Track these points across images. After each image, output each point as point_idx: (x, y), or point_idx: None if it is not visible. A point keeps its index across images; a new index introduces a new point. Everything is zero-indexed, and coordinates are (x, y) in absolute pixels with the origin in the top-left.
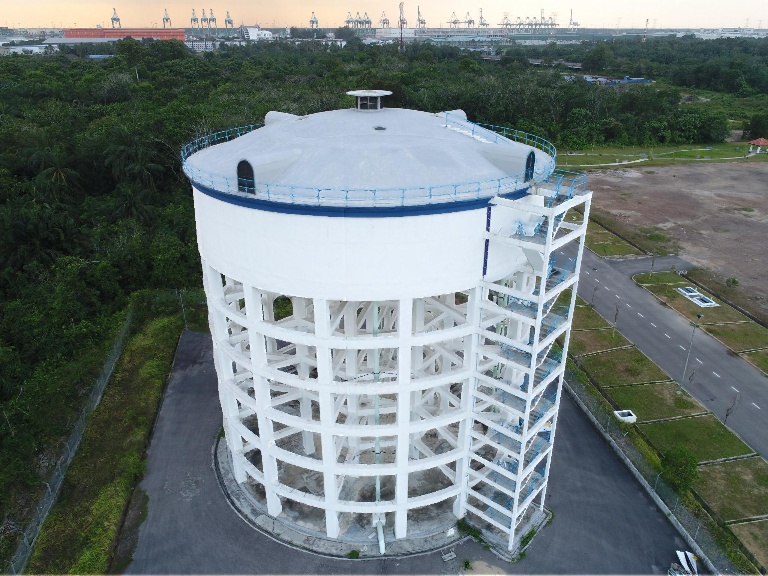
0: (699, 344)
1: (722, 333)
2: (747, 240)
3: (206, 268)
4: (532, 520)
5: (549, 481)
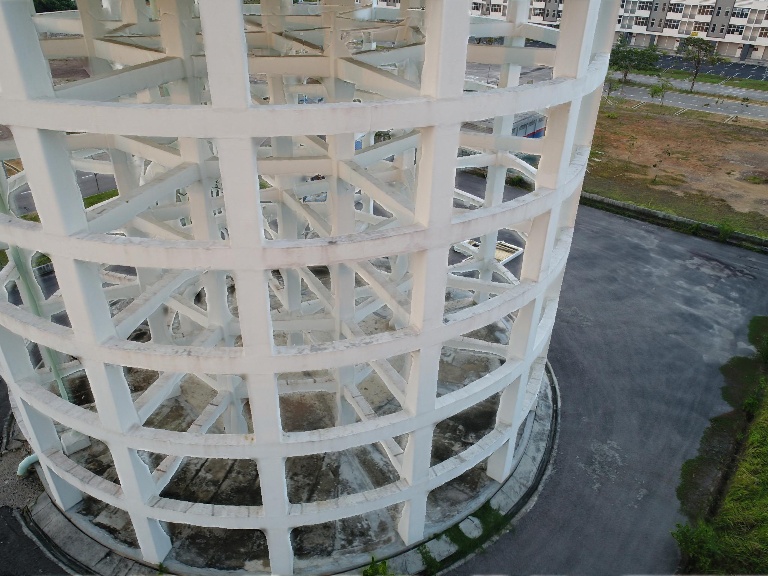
0: None
1: None
2: None
3: None
4: None
5: None
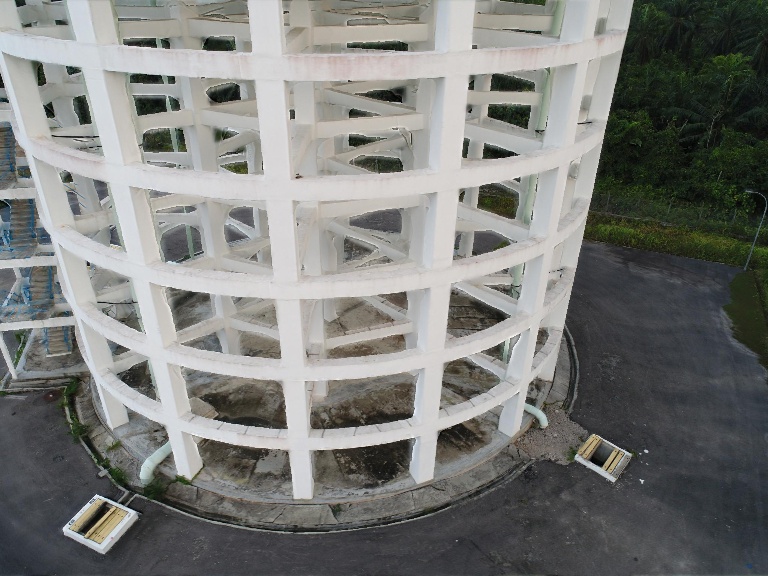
0: None
1: None
2: None
3: None
4: (22, 358)
5: (25, 431)
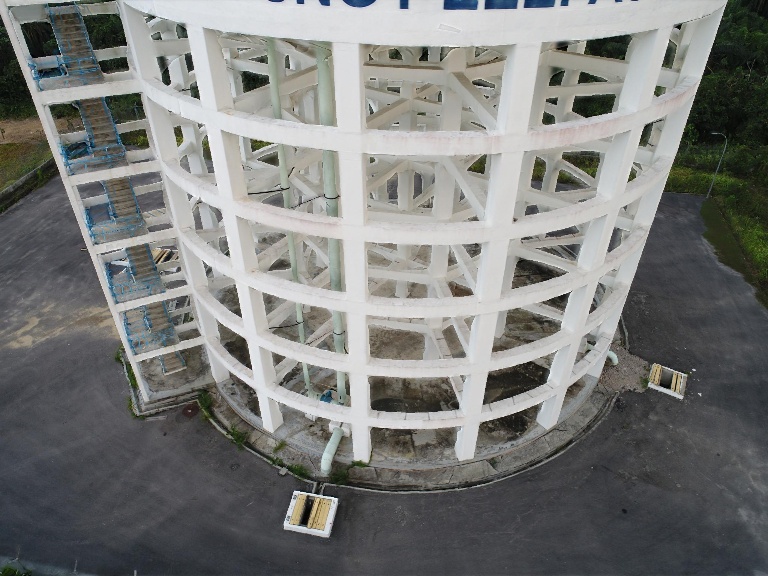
0: None
1: None
2: None
3: None
4: None
5: (188, 448)
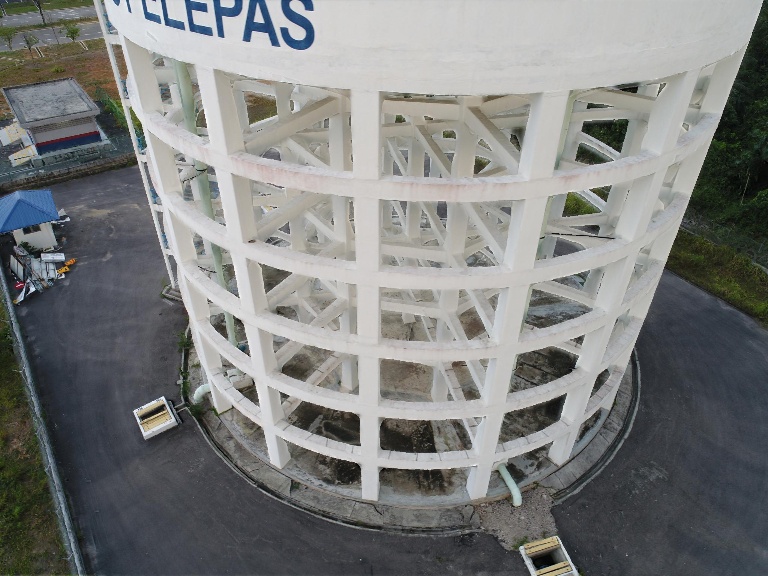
0: None
1: None
2: None
3: None
4: None
5: (159, 330)
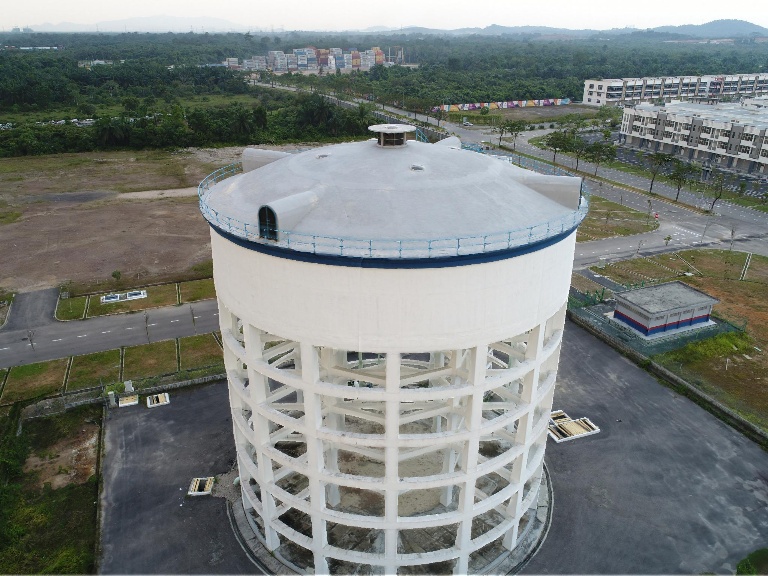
0: (213, 307)
1: (197, 296)
2: (4, 259)
3: (540, 331)
4: None
5: None
